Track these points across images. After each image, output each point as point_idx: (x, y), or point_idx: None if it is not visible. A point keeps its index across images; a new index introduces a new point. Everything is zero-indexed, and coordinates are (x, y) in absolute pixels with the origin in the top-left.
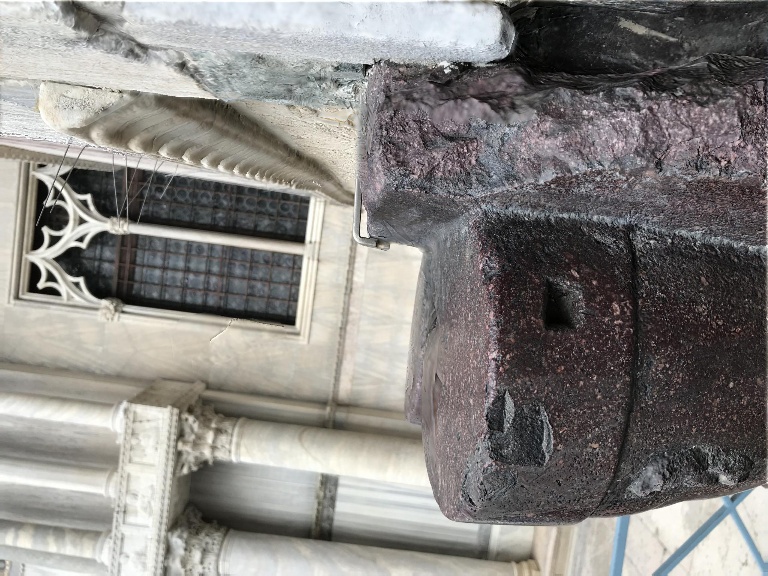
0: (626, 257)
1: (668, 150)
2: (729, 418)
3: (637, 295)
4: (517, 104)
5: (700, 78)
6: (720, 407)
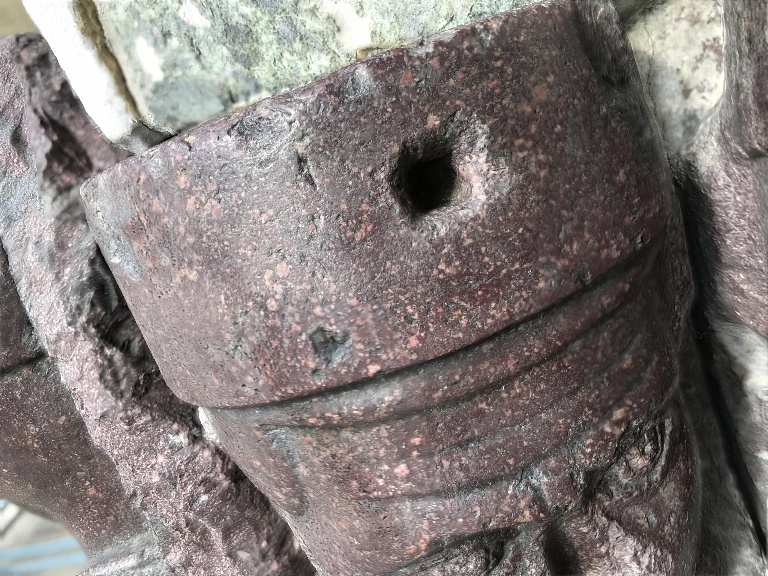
0: (29, 353)
1: (66, 362)
2: None
3: (1, 377)
4: (70, 194)
5: (142, 361)
6: None
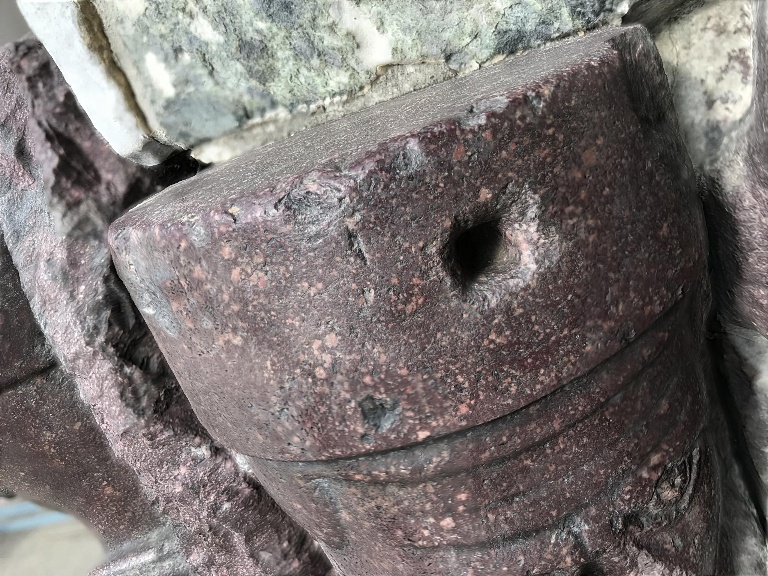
0: (42, 363)
1: (85, 379)
2: (6, 479)
3: (15, 387)
4: (79, 208)
5: (162, 377)
6: (2, 473)
